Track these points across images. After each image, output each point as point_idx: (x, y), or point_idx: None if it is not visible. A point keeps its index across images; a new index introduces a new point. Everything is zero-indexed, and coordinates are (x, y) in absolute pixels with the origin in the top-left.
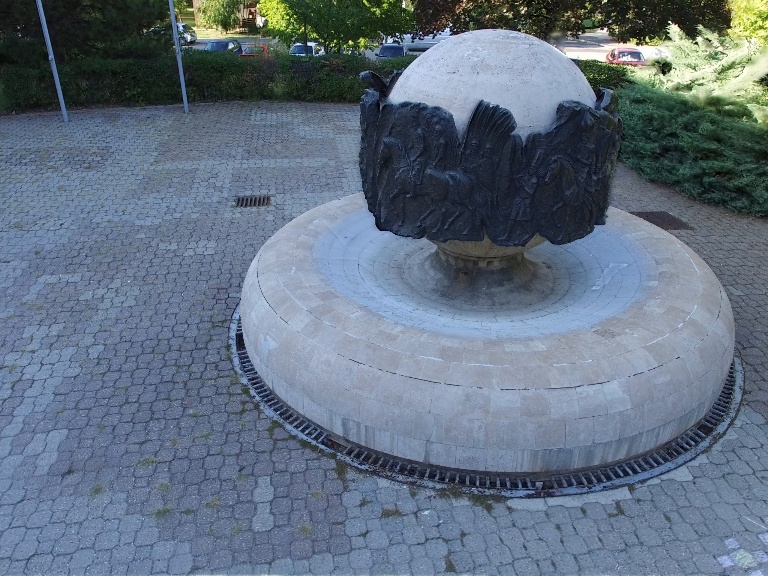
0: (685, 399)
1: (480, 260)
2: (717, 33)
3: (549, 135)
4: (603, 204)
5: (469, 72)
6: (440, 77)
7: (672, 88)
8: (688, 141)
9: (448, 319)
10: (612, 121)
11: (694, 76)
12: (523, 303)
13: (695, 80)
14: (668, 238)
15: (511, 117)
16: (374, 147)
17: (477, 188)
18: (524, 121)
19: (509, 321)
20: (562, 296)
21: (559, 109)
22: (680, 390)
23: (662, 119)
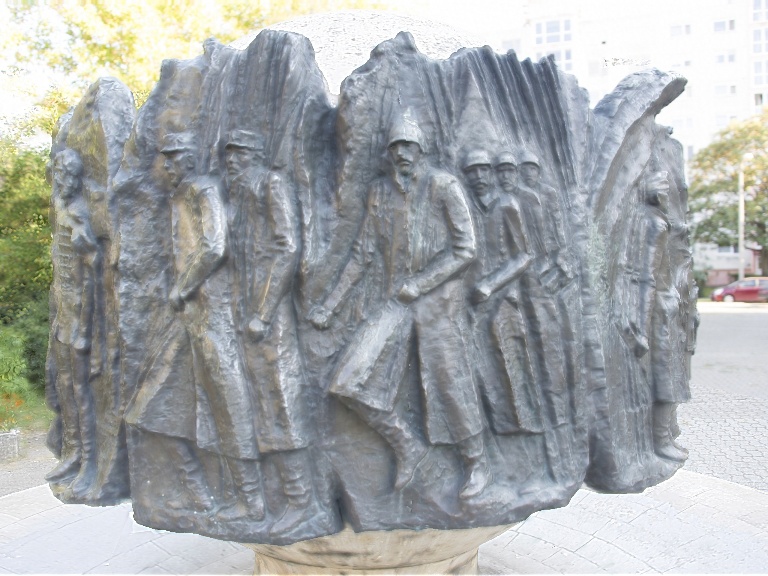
0: None
1: None
2: None
3: None
4: None
5: None
6: None
7: None
8: None
9: (530, 527)
10: None
11: None
12: None
13: None
14: None
15: None
16: None
17: None
18: None
19: None
20: None
21: None
22: None
23: None
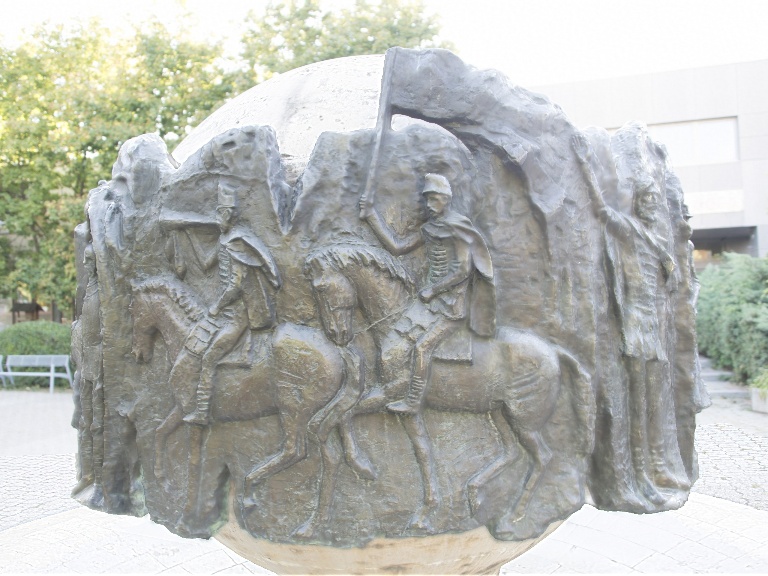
0: None
1: None
2: None
3: None
4: None
5: None
6: None
7: None
8: None
9: None
10: None
11: None
12: None
13: None
14: None
15: None
16: None
17: None
18: None
19: None
20: None
21: None
22: None
23: None
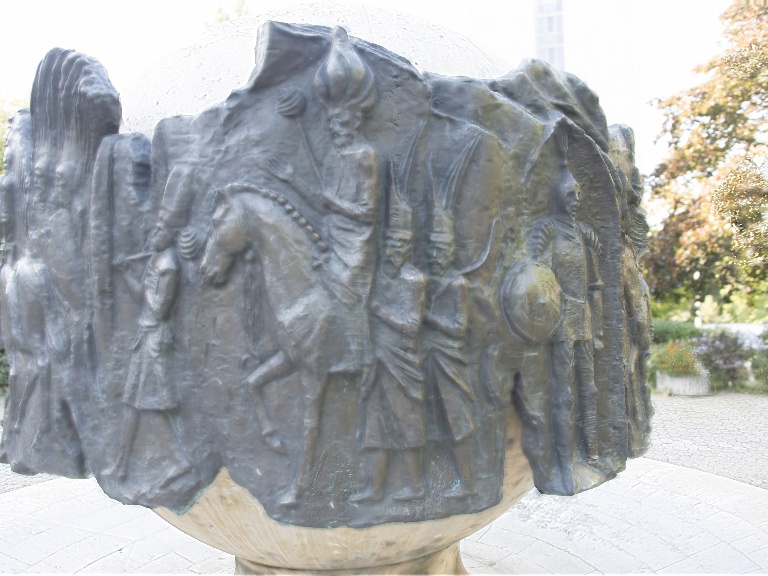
0: None
1: (266, 572)
2: None
3: (210, 121)
4: (557, 415)
5: None
6: None
7: None
8: None
9: None
10: (513, 115)
11: None
12: None
13: None
14: None
15: (83, 68)
16: None
17: (46, 300)
18: (189, 110)
19: None
20: None
21: (255, 49)
22: None
23: None
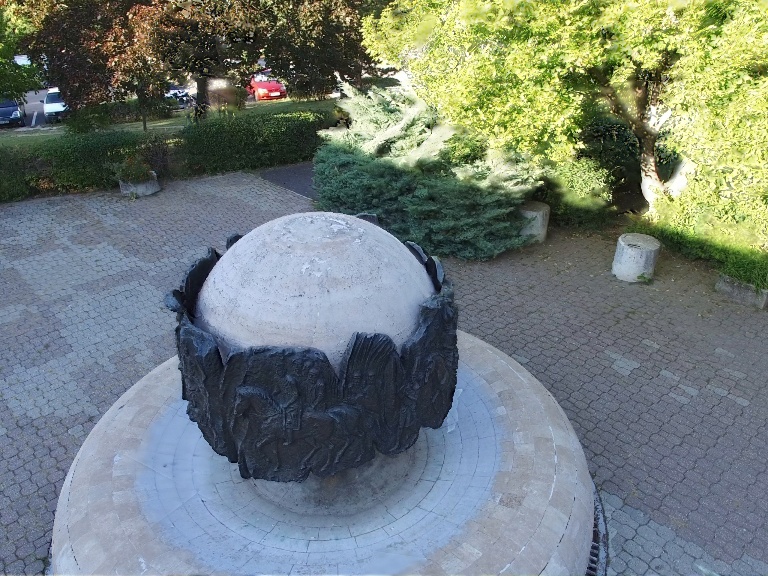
0: (590, 533)
1: None
2: (388, 90)
3: (421, 340)
4: None
5: (318, 292)
6: (284, 303)
7: (375, 153)
8: (414, 209)
9: (350, 542)
10: None
11: (387, 136)
12: (399, 477)
13: (388, 139)
14: (476, 345)
15: (391, 342)
16: (222, 397)
17: (365, 416)
18: (392, 331)
19: (406, 513)
20: (427, 450)
21: (423, 311)
22: (587, 529)
23: (380, 187)
